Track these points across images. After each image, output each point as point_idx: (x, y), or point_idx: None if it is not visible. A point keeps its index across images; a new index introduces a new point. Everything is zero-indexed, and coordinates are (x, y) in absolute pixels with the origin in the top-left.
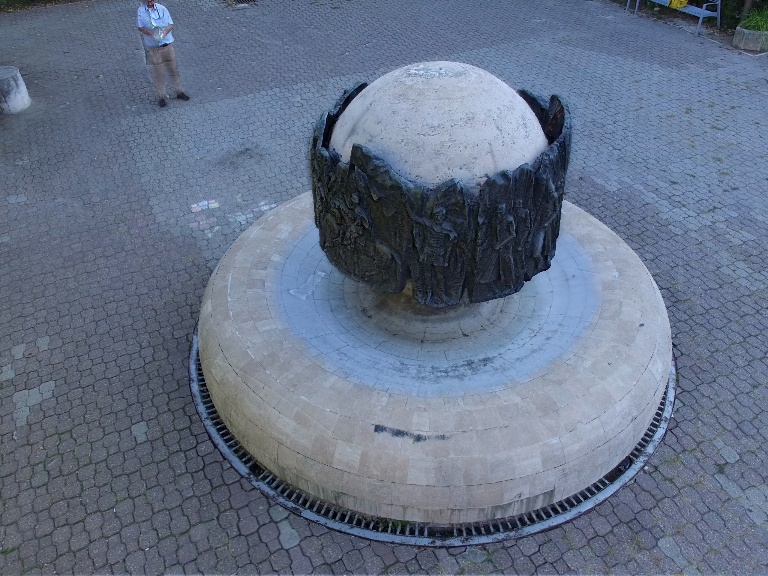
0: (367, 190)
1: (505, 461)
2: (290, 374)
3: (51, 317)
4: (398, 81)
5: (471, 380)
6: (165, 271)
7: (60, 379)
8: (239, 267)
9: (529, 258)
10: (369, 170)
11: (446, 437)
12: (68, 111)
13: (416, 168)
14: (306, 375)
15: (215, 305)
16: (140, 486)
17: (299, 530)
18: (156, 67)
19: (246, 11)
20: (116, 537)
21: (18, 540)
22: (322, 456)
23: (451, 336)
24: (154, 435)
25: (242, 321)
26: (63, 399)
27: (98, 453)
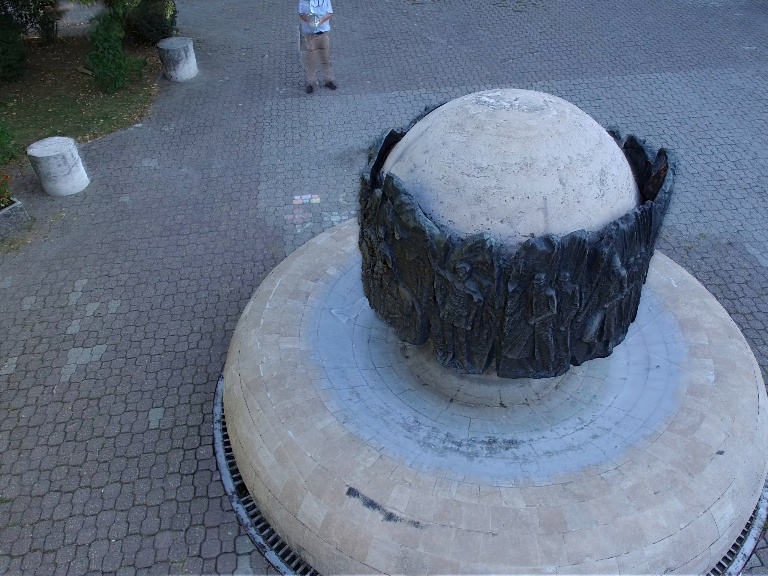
0: (394, 226)
1: (480, 575)
2: (289, 403)
3: (130, 282)
4: (463, 107)
5: (481, 463)
6: (244, 259)
7: (112, 345)
8: (291, 273)
9: (579, 340)
10: (395, 205)
11: (420, 525)
12: (225, 86)
13: (451, 211)
14: (304, 408)
15: (253, 308)
16: (133, 473)
17: (256, 571)
18: (308, 53)
19: (425, 6)
20: (93, 518)
21: (16, 492)
22: (289, 503)
23: (486, 402)
24: (166, 424)
25: (268, 332)
26: (107, 365)
27: (112, 428)
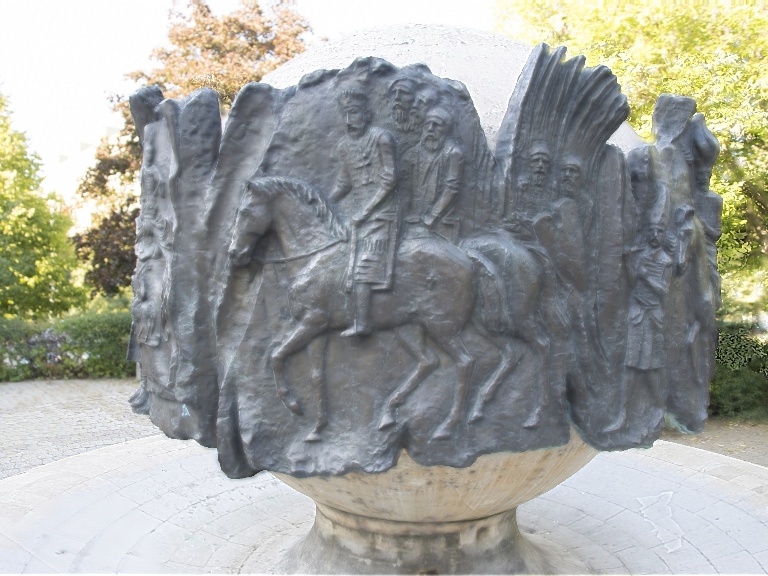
0: None
1: None
2: None
3: None
4: None
5: None
6: None
7: None
8: None
9: None
10: None
11: None
12: None
13: None
14: None
15: None
16: None
17: None
18: None
19: None
20: None
21: None
22: None
23: None
24: None
25: (670, 444)
26: None
27: None
